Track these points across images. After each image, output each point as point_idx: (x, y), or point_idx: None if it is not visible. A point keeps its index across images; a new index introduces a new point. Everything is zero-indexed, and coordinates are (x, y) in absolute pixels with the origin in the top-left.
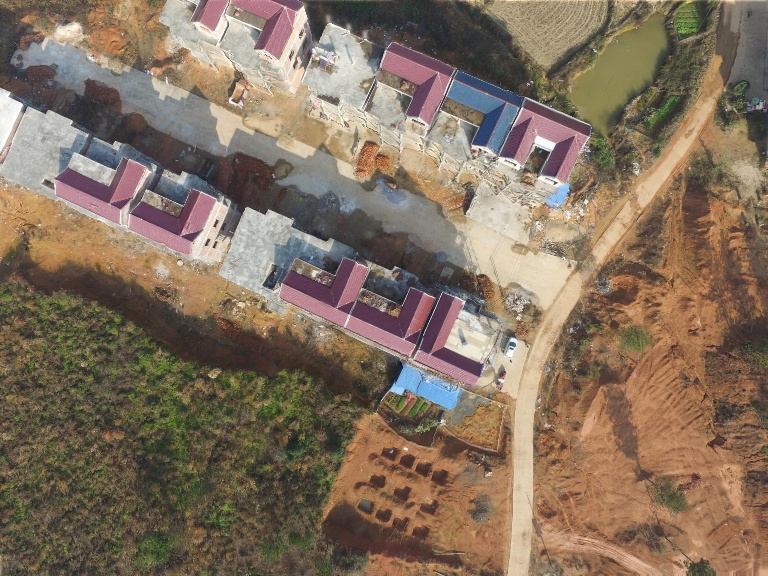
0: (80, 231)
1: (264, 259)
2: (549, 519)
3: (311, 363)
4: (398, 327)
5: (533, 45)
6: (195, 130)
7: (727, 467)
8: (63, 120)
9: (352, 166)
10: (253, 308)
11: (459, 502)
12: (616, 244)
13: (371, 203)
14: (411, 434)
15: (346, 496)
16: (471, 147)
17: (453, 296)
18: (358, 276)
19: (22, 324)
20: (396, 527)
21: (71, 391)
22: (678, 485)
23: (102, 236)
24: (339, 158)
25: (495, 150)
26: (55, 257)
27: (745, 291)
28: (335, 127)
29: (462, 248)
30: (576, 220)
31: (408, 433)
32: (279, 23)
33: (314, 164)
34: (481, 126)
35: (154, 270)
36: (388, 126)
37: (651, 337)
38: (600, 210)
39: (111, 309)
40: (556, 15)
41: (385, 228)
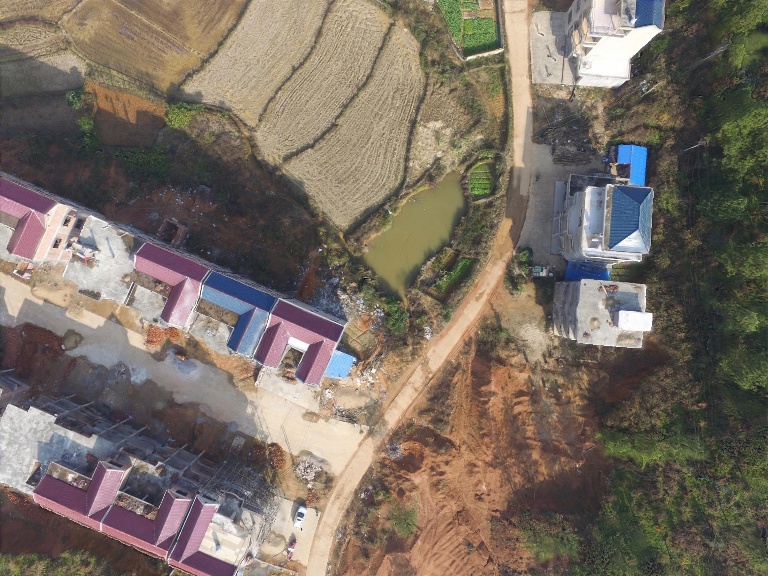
0: None
1: (27, 457)
2: None
3: (102, 537)
4: (152, 532)
5: (330, 205)
6: None
7: None
8: None
9: (142, 336)
10: None
11: None
12: (407, 408)
13: (162, 373)
14: None
15: None
16: None
17: (202, 504)
18: (112, 481)
19: None
20: None
21: None
22: None
23: None
24: (129, 328)
25: (249, 352)
26: None
27: (529, 455)
28: None
29: (253, 417)
30: (367, 387)
31: None
32: (28, 225)
33: (104, 334)
34: (235, 327)
35: None
36: (150, 321)
37: (436, 504)
38: (391, 376)
39: None
40: (353, 174)
41: (176, 398)
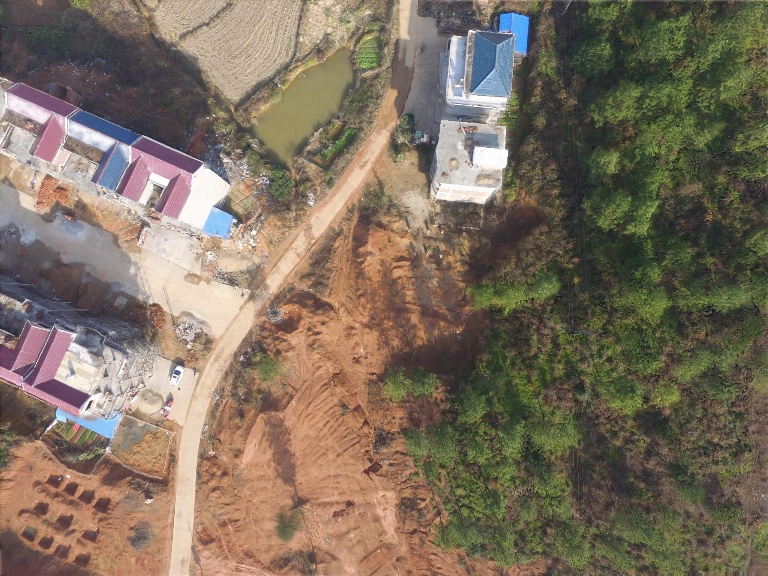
0: None
1: None
2: (206, 546)
3: None
4: (10, 359)
5: (223, 79)
6: None
7: (382, 494)
8: None
9: (33, 198)
10: None
11: (119, 529)
12: (289, 273)
13: (50, 234)
14: (74, 462)
15: (10, 523)
16: None
17: (57, 329)
18: None
19: None
20: (58, 554)
21: None
22: (333, 512)
23: None
24: (21, 190)
25: (111, 186)
26: None
27: (408, 319)
28: None
29: (136, 278)
30: (248, 250)
31: (71, 461)
32: None
33: None
34: (100, 163)
35: None
36: (24, 163)
37: (312, 365)
38: (273, 240)
39: None
40: (245, 50)
41: (63, 258)
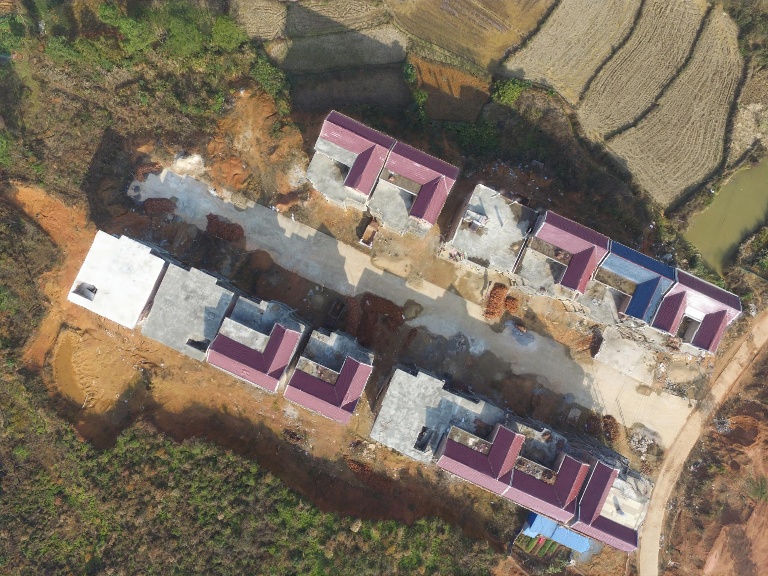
0: (205, 371)
1: (415, 421)
2: None
3: (443, 505)
4: (555, 496)
5: (652, 183)
6: (323, 269)
7: None
8: (208, 278)
9: (481, 307)
10: (384, 450)
11: None
12: (733, 383)
13: (500, 345)
14: (543, 575)
15: None
16: (619, 311)
17: (611, 468)
18: (516, 445)
19: (153, 474)
20: None
21: (207, 543)
22: None
23: (228, 377)
24: (468, 299)
25: (648, 320)
26: (179, 398)
27: None
28: (464, 268)
29: (589, 390)
30: (697, 361)
31: (540, 575)
32: (437, 191)
33: (443, 305)
34: (634, 296)
35: (283, 412)
36: (538, 289)
37: None
38: (719, 351)
39: (246, 459)
40: (674, 154)
41: (514, 370)
